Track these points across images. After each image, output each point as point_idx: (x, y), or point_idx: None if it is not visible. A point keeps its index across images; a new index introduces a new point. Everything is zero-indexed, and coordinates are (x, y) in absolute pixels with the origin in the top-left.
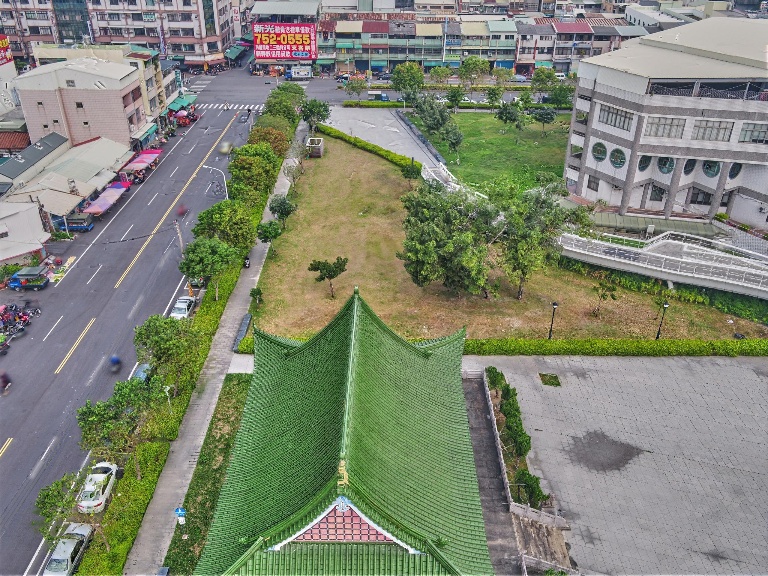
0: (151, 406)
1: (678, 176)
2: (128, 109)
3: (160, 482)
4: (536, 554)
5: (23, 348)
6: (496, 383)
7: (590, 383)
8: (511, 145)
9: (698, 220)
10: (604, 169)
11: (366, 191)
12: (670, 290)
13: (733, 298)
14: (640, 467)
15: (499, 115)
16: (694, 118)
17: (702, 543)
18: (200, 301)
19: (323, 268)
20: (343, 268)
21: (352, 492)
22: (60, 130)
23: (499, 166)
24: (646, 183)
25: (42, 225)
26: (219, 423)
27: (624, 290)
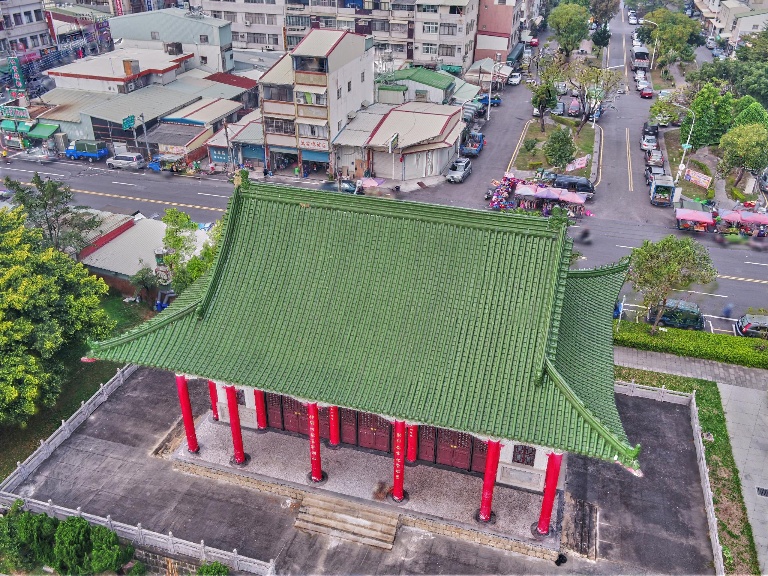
0: None
1: None
2: None
3: None
4: None
5: (727, 253)
6: None
7: None
8: None
9: None
10: None
11: None
12: None
13: None
14: None
15: None
16: None
17: None
18: None
19: None
20: None
21: None
22: None
23: None
24: None
25: None
26: None
27: None
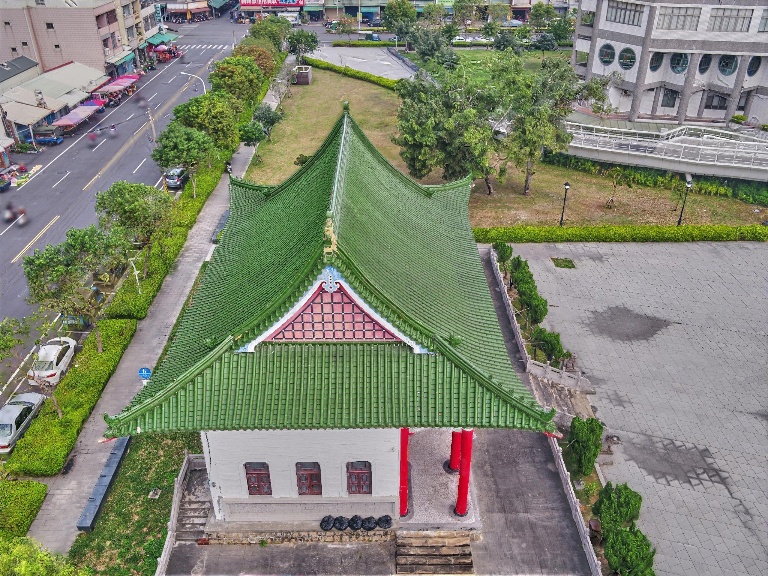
0: (109, 251)
1: (693, 74)
2: (102, 31)
3: (125, 357)
4: None
5: None
6: (505, 258)
7: (608, 265)
8: None
9: (714, 124)
10: None
11: (357, 110)
12: None
13: (758, 188)
14: (670, 337)
15: (496, 45)
16: (710, 6)
17: (747, 404)
18: (176, 201)
19: None
20: None
21: (342, 263)
22: (29, 53)
23: None
24: (657, 86)
25: (4, 130)
26: None
27: (639, 186)
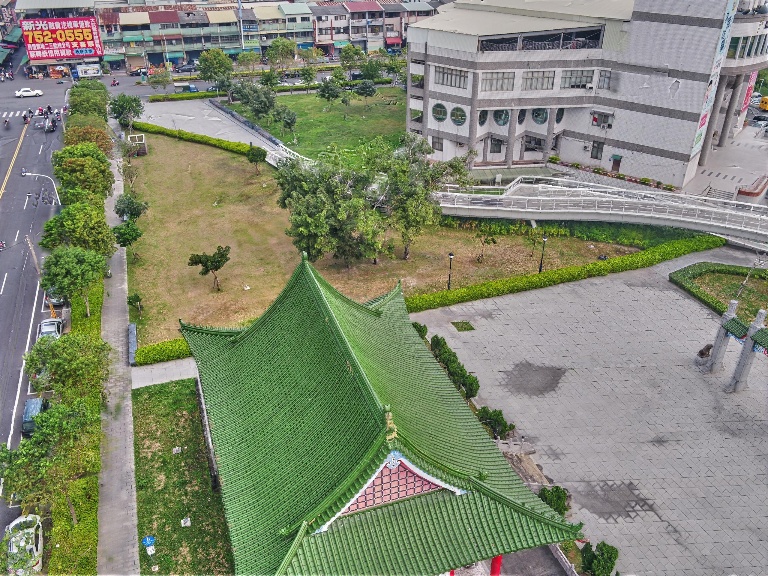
0: (89, 431)
1: (514, 126)
2: None
3: (100, 520)
4: None
5: None
6: (422, 337)
7: (499, 322)
8: (340, 121)
9: (535, 165)
10: (446, 128)
11: (211, 181)
12: (536, 228)
13: (588, 226)
14: (570, 384)
15: (321, 93)
16: (521, 70)
17: (644, 434)
18: (67, 321)
19: (206, 260)
20: (227, 257)
21: (402, 445)
22: None
23: (337, 141)
24: (486, 137)
25: None
26: (145, 442)
27: (495, 235)
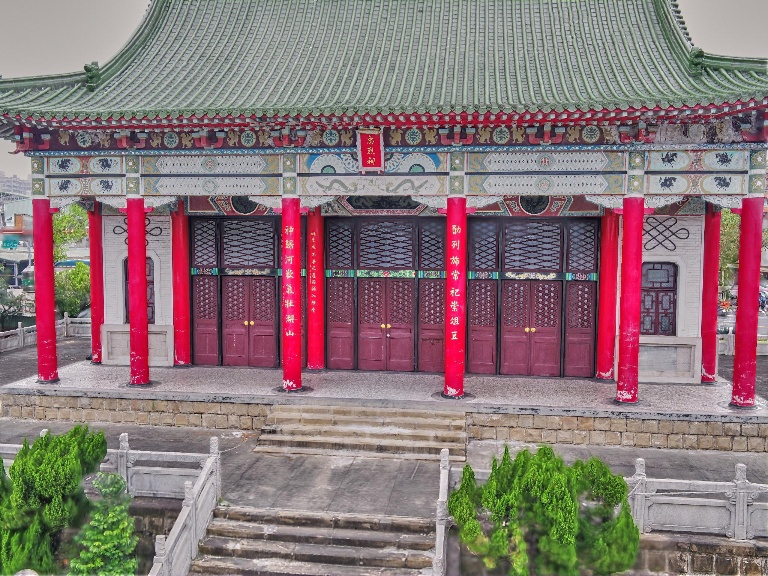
0: None
1: None
2: None
3: None
4: (257, 568)
5: None
6: None
7: None
8: None
9: None
10: None
11: None
12: None
13: None
14: None
15: None
16: None
17: None
18: None
19: None
20: None
21: None
22: None
23: None
24: None
25: None
26: None
27: None
